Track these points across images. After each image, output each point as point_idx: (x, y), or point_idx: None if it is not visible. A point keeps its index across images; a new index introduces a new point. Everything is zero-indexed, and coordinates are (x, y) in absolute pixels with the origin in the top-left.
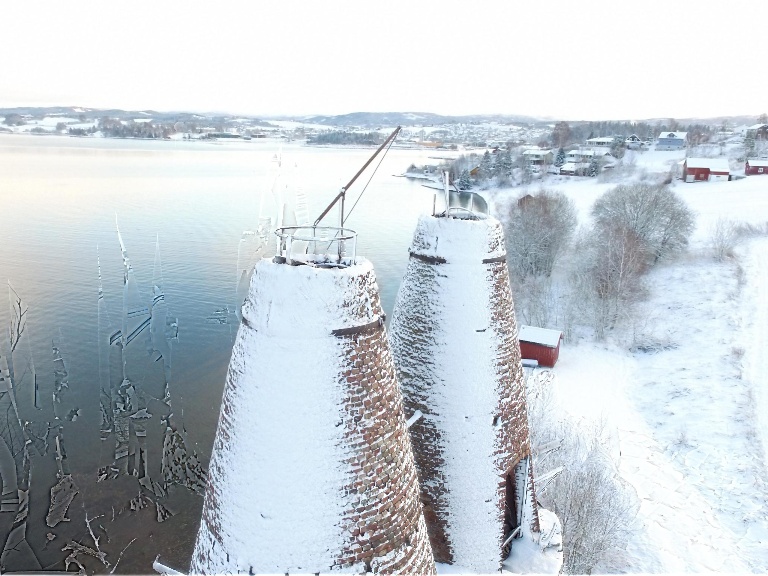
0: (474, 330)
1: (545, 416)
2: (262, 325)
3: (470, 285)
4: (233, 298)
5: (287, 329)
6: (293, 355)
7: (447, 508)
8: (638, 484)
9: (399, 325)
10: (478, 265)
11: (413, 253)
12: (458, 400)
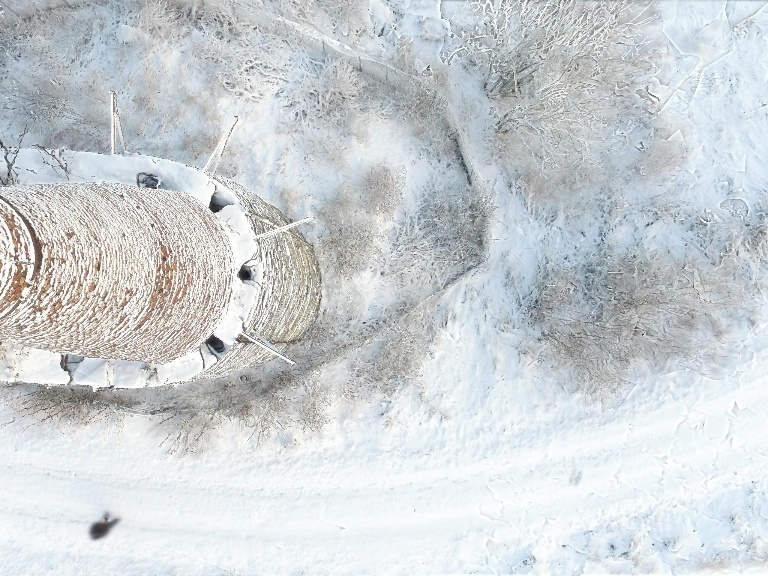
0: None
1: None
2: None
3: None
4: None
5: None
6: None
7: None
8: (767, 393)
9: None
10: None
11: None
12: None
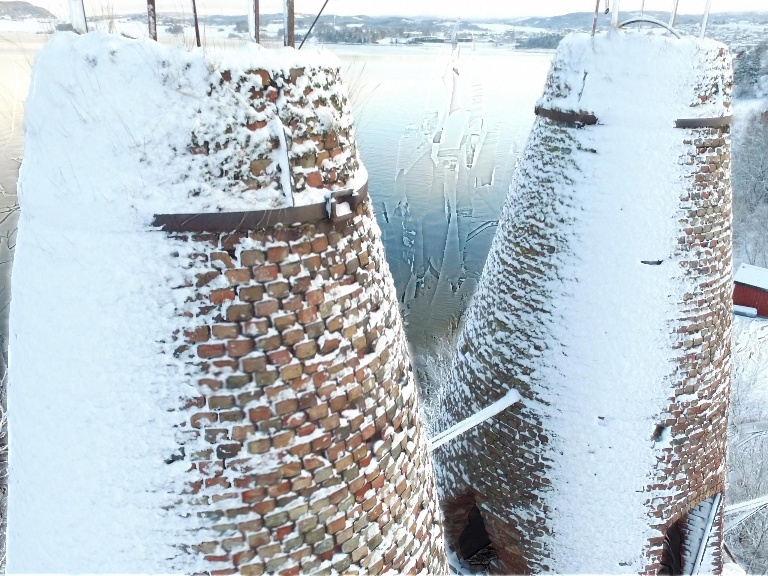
0: (637, 260)
1: (758, 382)
2: (18, 189)
3: (640, 170)
4: (386, 200)
5: (47, 201)
6: (62, 270)
7: (546, 559)
8: None
9: (502, 238)
10: (664, 130)
11: (539, 107)
12: (587, 385)
